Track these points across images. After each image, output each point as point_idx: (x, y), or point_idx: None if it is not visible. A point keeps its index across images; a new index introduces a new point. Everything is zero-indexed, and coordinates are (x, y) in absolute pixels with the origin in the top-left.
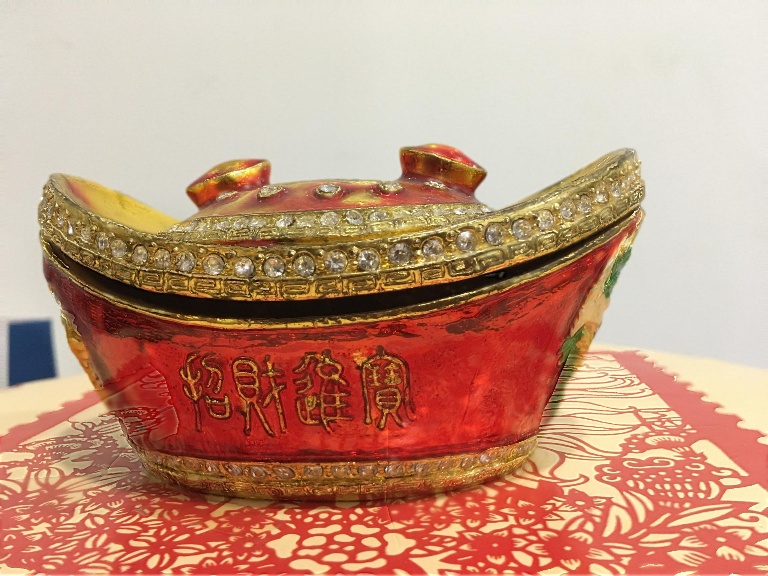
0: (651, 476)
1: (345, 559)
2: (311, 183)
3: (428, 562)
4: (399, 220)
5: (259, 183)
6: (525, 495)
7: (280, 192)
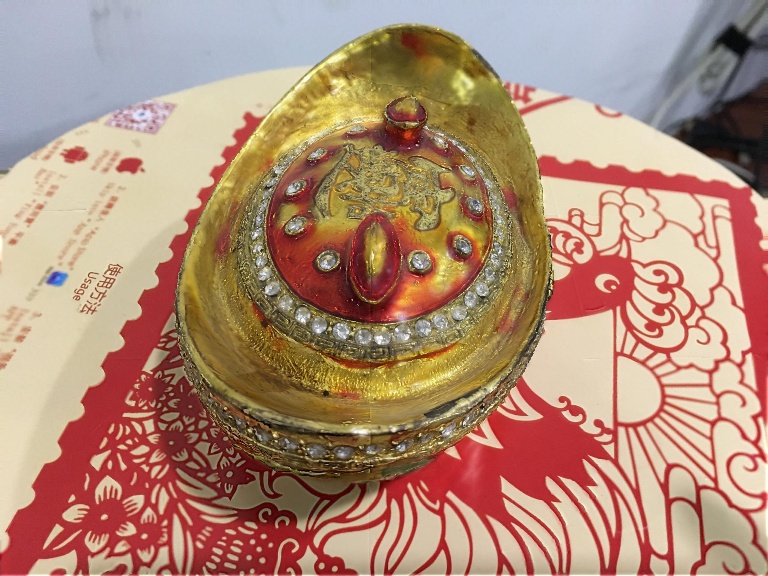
0: (259, 547)
1: None
2: (320, 173)
3: None
4: (242, 246)
5: (392, 137)
6: None
7: (309, 161)
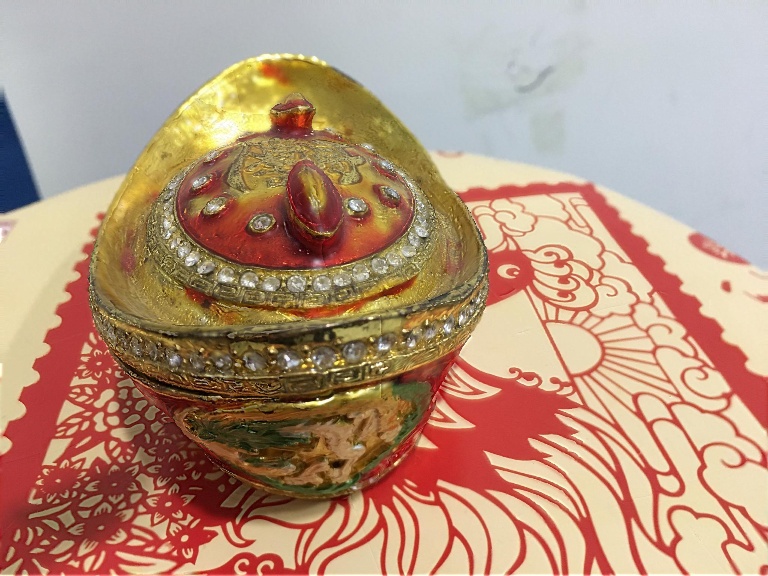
0: None
1: (110, 412)
2: (224, 164)
3: (96, 451)
4: (157, 246)
5: (286, 128)
6: (205, 499)
7: (207, 162)
